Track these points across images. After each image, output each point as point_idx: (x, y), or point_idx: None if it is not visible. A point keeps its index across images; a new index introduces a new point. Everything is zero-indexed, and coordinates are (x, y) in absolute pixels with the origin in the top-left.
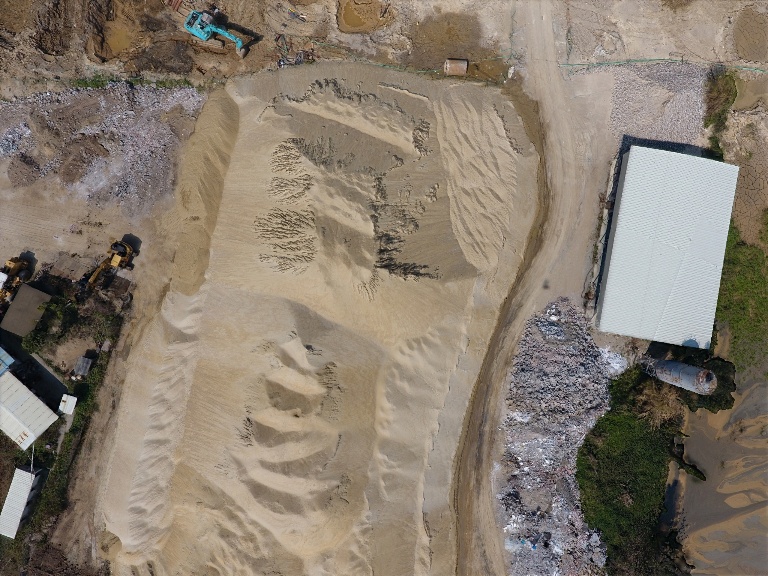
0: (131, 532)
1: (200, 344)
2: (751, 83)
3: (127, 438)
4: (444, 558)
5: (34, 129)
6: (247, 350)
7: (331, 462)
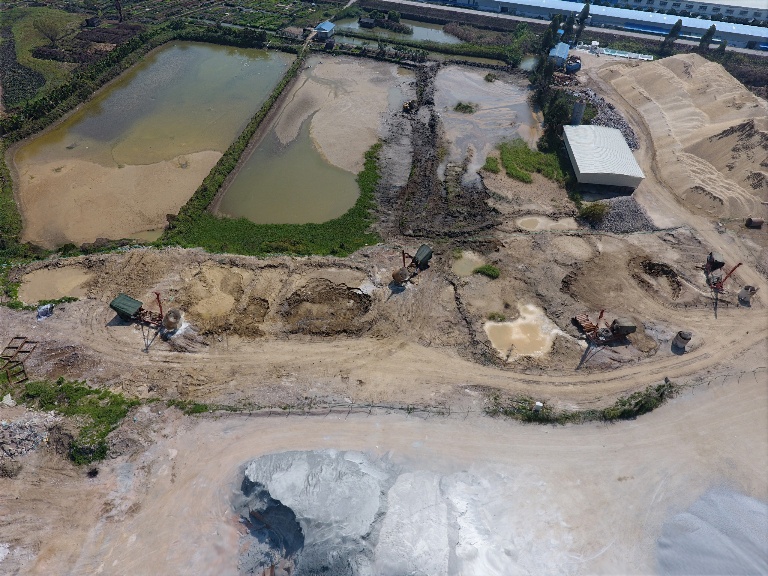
0: None
1: None
2: (566, 228)
3: None
4: None
5: None
6: None
7: None
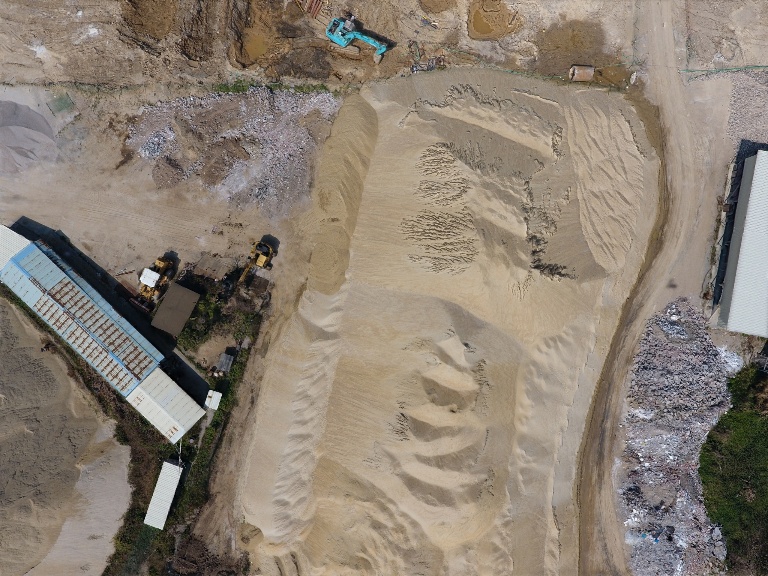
0: (276, 524)
1: (342, 342)
2: None
3: (268, 433)
4: (569, 551)
5: (179, 133)
6: (398, 348)
7: (481, 456)
